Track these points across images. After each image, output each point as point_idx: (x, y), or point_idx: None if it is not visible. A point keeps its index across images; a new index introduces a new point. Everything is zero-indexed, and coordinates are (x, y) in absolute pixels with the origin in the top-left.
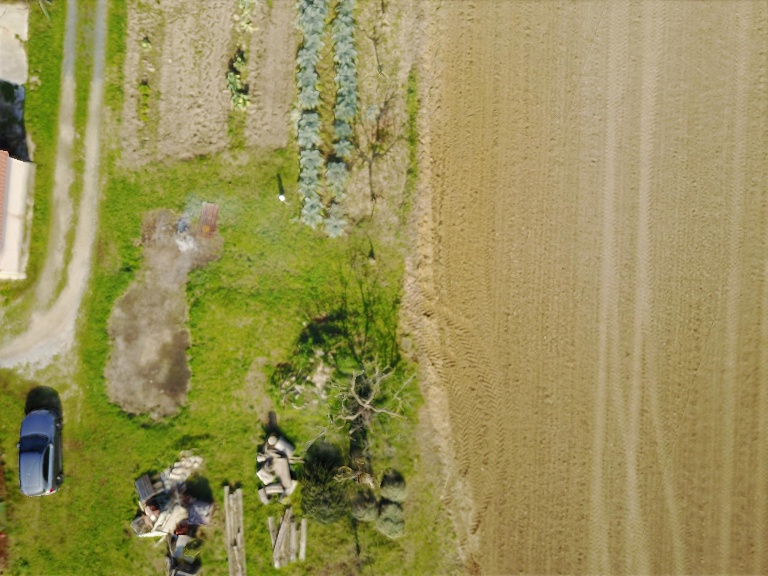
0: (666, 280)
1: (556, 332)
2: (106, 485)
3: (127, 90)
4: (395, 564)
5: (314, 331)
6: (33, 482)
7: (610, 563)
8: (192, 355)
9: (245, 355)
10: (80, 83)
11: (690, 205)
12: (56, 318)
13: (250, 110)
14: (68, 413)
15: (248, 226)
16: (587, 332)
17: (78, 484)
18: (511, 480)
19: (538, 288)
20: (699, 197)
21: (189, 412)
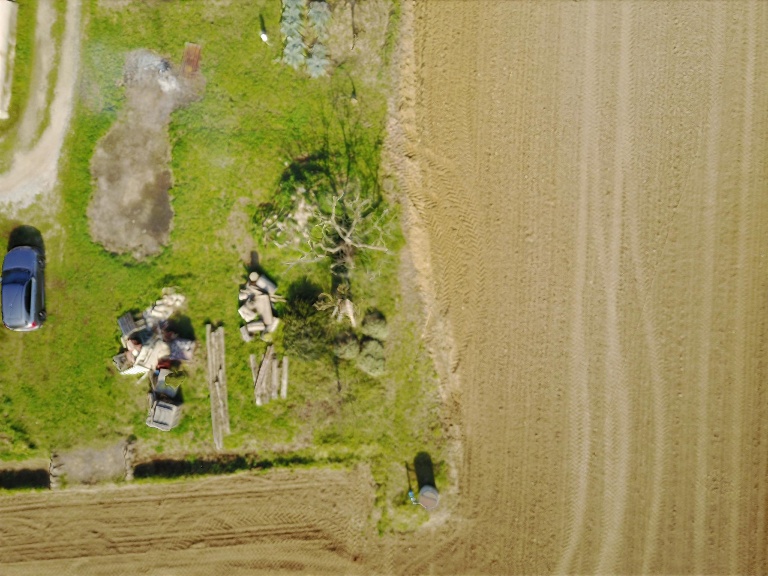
0: (647, 118)
1: (537, 171)
2: (88, 323)
3: None
4: (376, 402)
5: (296, 170)
6: (15, 313)
7: (589, 398)
8: (174, 195)
9: (227, 195)
10: None
11: (671, 42)
12: (38, 158)
13: None
14: (51, 252)
15: (230, 67)
16: (568, 171)
17: (61, 322)
18: (491, 318)
19: (519, 128)
20: (680, 33)
21: (171, 251)
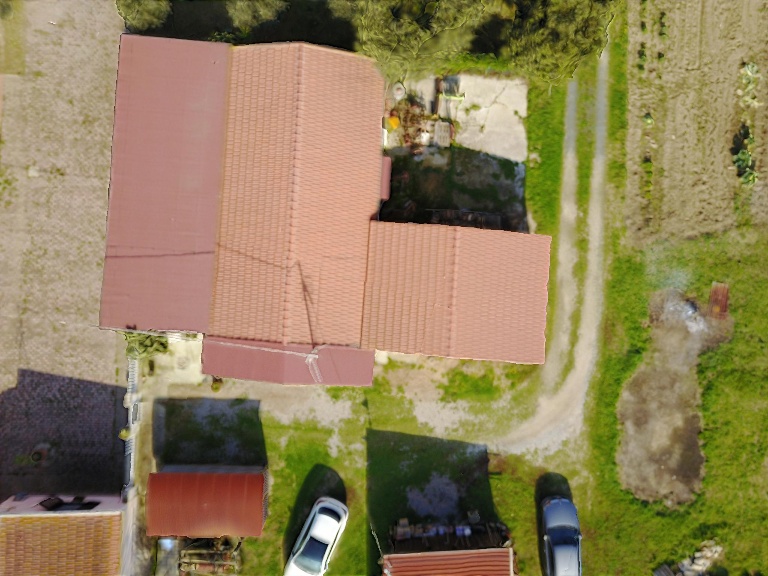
0: None
1: None
2: (621, 575)
3: (630, 167)
4: None
5: None
6: None
7: None
8: (705, 440)
9: (760, 439)
10: (582, 160)
11: None
12: (563, 402)
13: (756, 187)
14: (578, 500)
15: (759, 306)
16: None
17: (591, 575)
18: None
19: None
20: None
21: (705, 499)
